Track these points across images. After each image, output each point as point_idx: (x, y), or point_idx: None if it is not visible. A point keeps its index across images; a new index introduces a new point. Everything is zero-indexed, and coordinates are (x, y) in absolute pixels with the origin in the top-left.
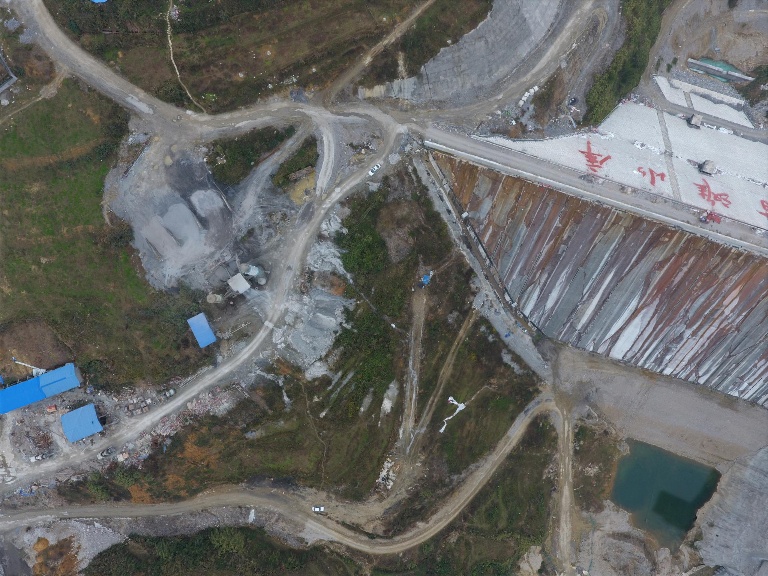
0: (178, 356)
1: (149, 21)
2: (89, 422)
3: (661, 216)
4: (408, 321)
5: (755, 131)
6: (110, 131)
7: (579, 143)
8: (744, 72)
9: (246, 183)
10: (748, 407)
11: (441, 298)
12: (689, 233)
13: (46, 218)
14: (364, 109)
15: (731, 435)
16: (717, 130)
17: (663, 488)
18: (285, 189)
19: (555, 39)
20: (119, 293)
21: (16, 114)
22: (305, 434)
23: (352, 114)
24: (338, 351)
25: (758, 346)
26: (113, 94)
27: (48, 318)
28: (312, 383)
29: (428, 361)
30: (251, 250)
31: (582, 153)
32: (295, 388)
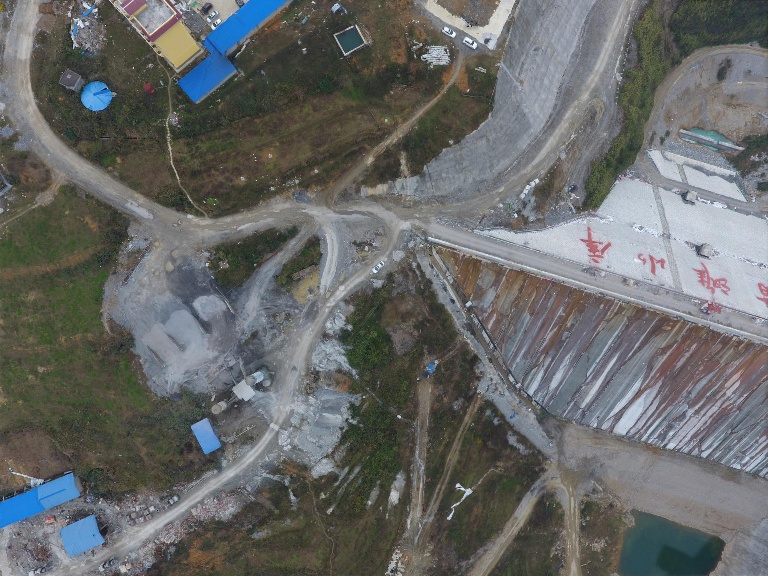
0: (182, 462)
1: (148, 128)
2: (90, 535)
3: (663, 308)
4: (414, 411)
5: (748, 205)
6: (109, 238)
7: (579, 230)
8: (734, 141)
9: (249, 285)
10: (750, 479)
11: (446, 387)
12: (691, 323)
13: (43, 327)
14: (367, 207)
15: (734, 506)
16: (711, 205)
17: (669, 558)
18: (288, 288)
19: (554, 130)
20: (120, 400)
21: (11, 222)
22: (312, 532)
23: (355, 212)
24: (344, 447)
25: (759, 424)
26: (112, 200)
27: (46, 427)
28: (319, 481)
29: (434, 449)
30: (255, 351)
31: (583, 242)
32: (302, 487)
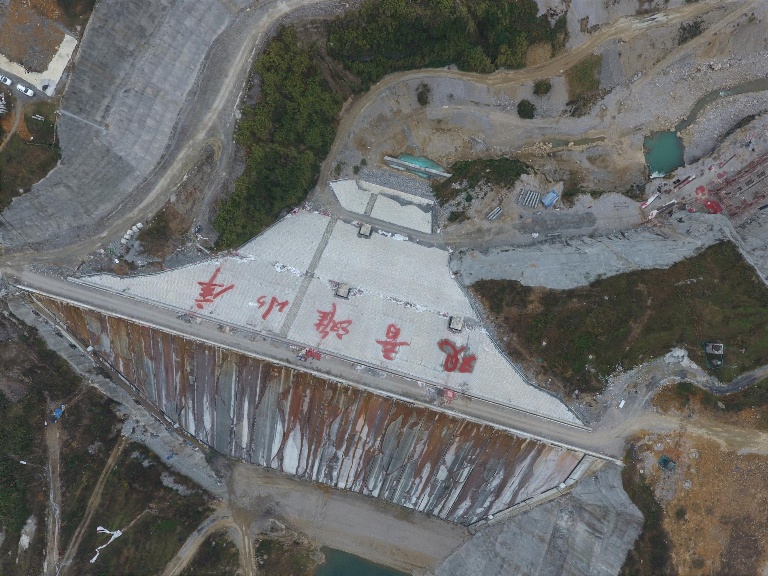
0: None
1: None
2: None
3: (257, 356)
4: (43, 455)
5: (431, 236)
6: None
7: (205, 272)
8: (444, 167)
9: None
10: (424, 519)
11: (72, 432)
12: (293, 369)
13: None
14: None
15: (415, 545)
16: (391, 237)
17: None
18: None
19: (165, 171)
20: None
21: None
22: None
23: None
24: None
25: (407, 466)
26: None
27: None
28: None
29: (71, 493)
30: None
31: (200, 285)
32: None
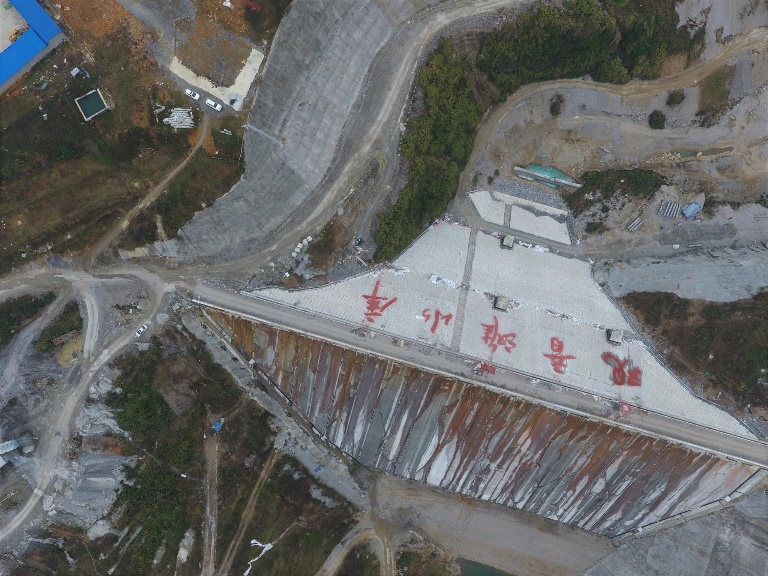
0: None
1: None
2: None
3: (433, 370)
4: (202, 468)
5: (572, 247)
6: None
7: (366, 285)
8: (573, 178)
9: (7, 351)
10: (568, 531)
11: (232, 445)
12: (466, 383)
13: None
14: (129, 270)
15: (556, 557)
16: (532, 248)
17: None
18: (52, 353)
19: (332, 185)
20: None
21: None
22: None
23: (116, 276)
24: (122, 508)
25: (562, 479)
26: None
27: None
28: (94, 543)
29: (227, 506)
30: (18, 416)
31: (365, 298)
32: (77, 549)
